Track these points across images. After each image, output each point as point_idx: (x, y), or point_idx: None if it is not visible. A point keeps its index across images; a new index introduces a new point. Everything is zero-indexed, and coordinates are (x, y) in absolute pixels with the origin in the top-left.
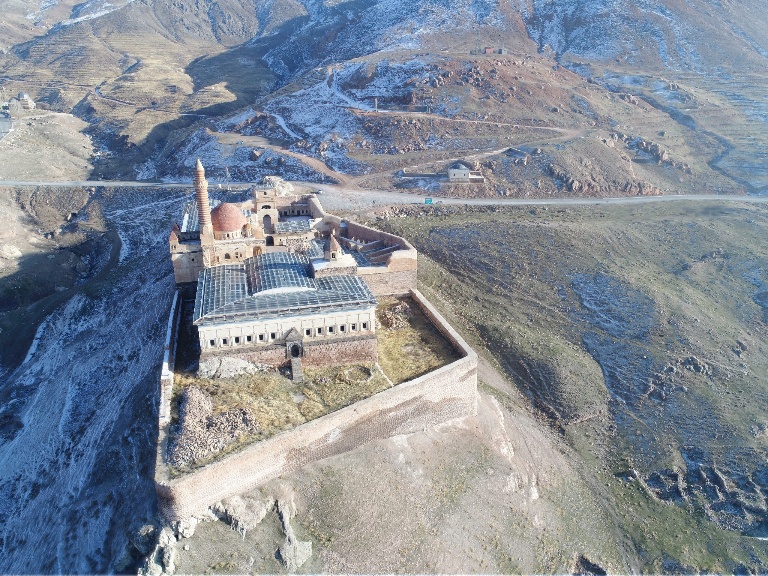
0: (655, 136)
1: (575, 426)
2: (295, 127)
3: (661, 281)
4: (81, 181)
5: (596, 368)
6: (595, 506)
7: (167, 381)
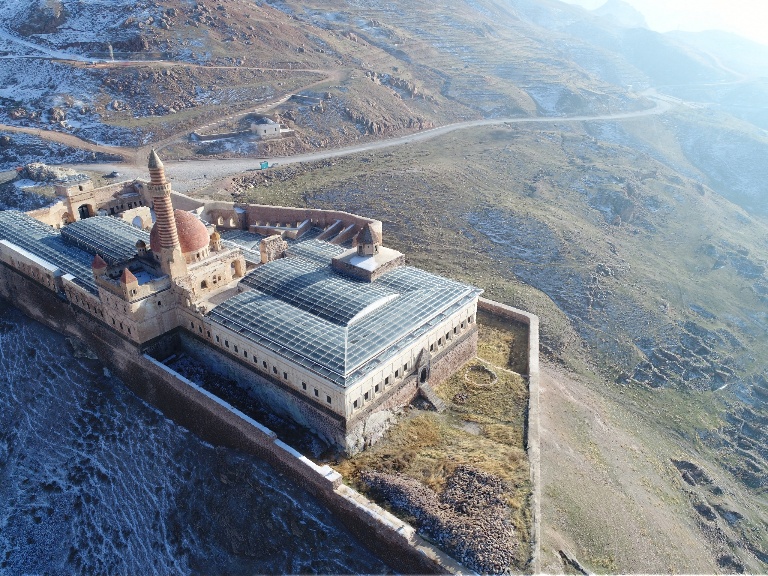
0: (392, 72)
1: (565, 353)
2: None
3: (529, 205)
4: None
5: (545, 296)
6: (632, 414)
7: (338, 480)
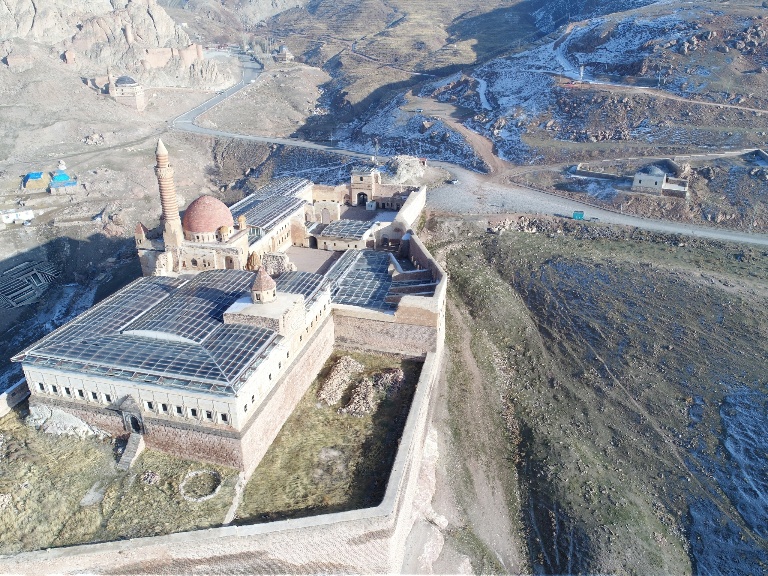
0: None
1: None
2: (492, 96)
3: None
4: (271, 137)
5: (681, 574)
6: None
7: None
